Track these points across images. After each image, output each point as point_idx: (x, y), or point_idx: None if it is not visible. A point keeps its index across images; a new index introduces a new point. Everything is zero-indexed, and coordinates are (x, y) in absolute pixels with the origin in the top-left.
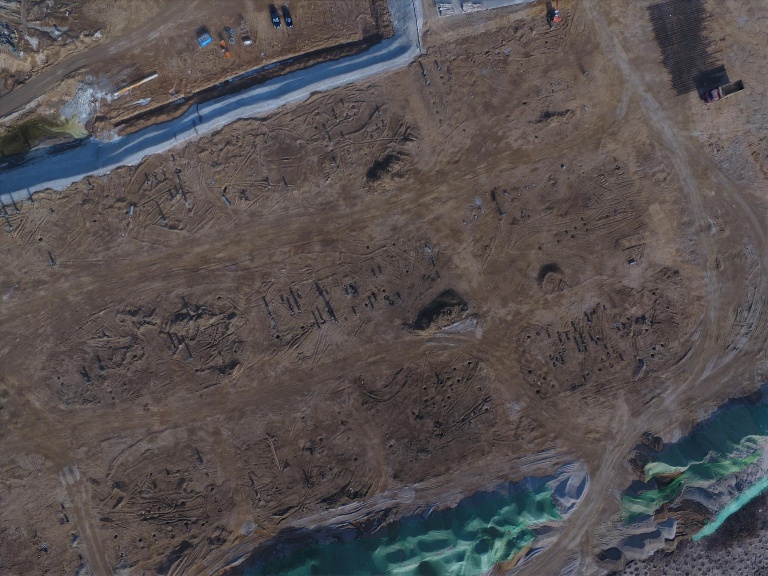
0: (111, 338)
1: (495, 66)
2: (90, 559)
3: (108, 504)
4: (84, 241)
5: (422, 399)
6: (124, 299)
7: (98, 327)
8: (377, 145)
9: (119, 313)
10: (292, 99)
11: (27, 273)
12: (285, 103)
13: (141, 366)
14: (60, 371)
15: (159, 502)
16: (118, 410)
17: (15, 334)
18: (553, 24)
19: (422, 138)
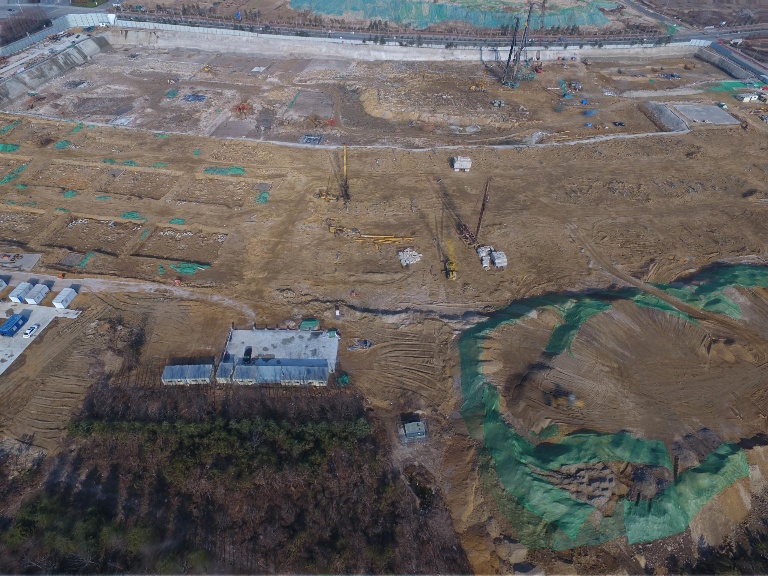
0: None
1: (728, 136)
2: (594, 258)
3: None
4: None
5: (767, 221)
6: None
7: None
8: (686, 149)
9: None
10: (639, 135)
11: None
12: (637, 136)
13: None
14: None
15: None
16: None
17: (528, 180)
18: (747, 128)
19: (706, 149)
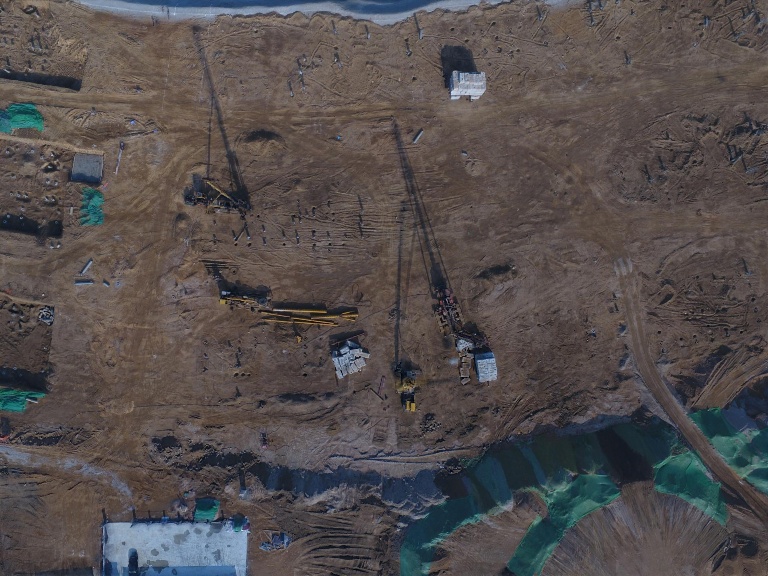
0: (674, 141)
1: None
2: (634, 350)
3: (656, 300)
4: (658, 45)
5: None
6: (690, 106)
7: (663, 129)
8: None
9: (685, 118)
10: None
11: (602, 68)
12: None
13: (698, 172)
14: (623, 166)
15: (703, 305)
16: (673, 211)
17: (585, 124)
18: None
19: None
